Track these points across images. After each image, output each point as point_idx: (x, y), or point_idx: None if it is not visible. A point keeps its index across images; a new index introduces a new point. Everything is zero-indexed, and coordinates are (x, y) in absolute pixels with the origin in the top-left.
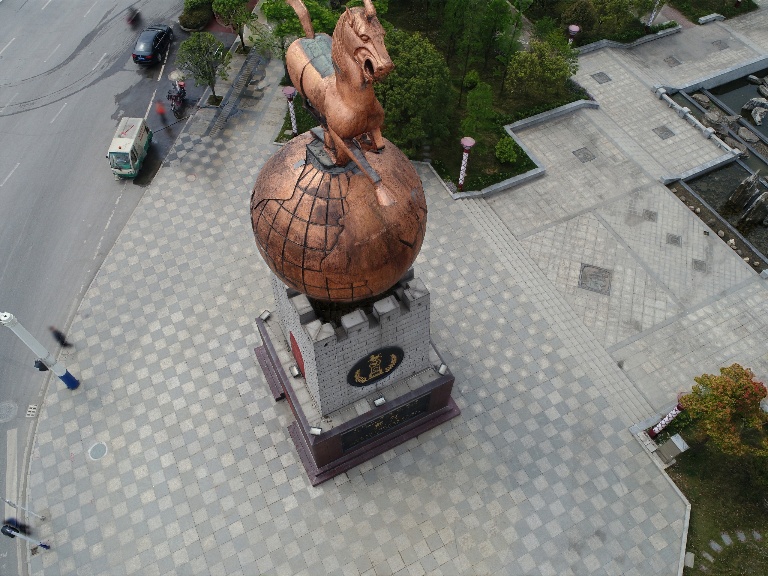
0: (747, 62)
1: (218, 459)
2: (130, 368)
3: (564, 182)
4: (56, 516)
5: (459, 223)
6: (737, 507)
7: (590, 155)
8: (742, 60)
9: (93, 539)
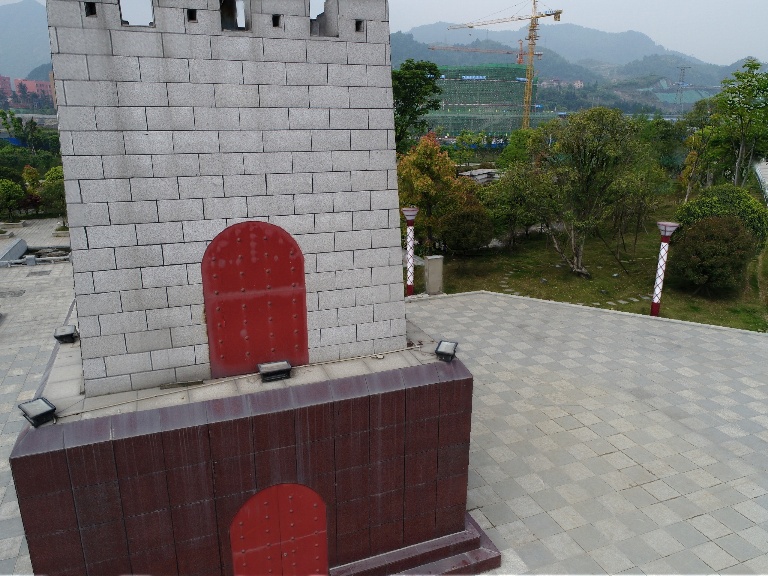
0: (11, 245)
1: None
2: None
3: (34, 307)
4: None
5: (4, 356)
6: (480, 281)
7: (16, 292)
8: (2, 250)
9: None
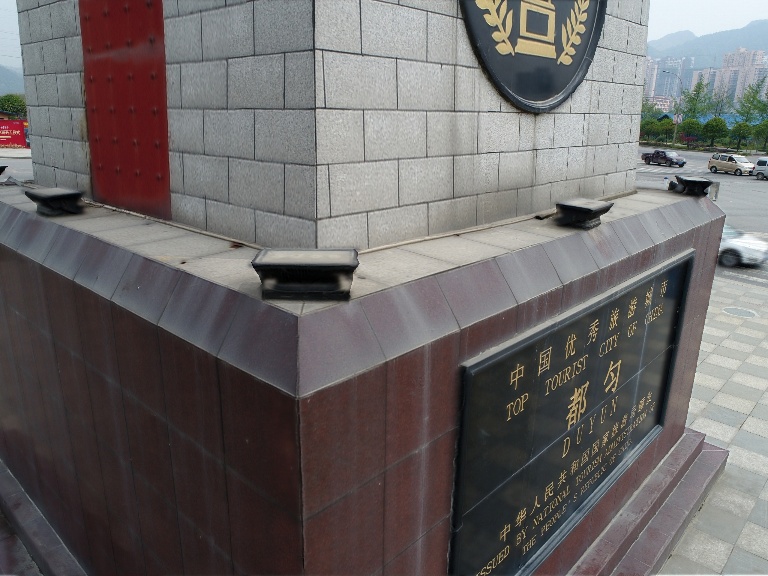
0: None
1: None
2: None
3: None
4: None
5: None
6: None
7: None
8: None
9: None
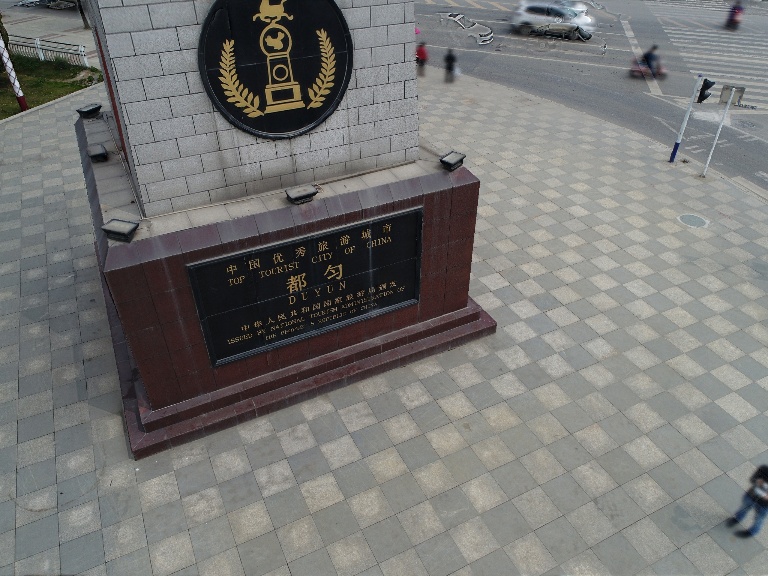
0: None
1: (501, 211)
2: (751, 311)
3: None
4: (688, 178)
5: None
6: None
7: None
8: None
9: (623, 165)
